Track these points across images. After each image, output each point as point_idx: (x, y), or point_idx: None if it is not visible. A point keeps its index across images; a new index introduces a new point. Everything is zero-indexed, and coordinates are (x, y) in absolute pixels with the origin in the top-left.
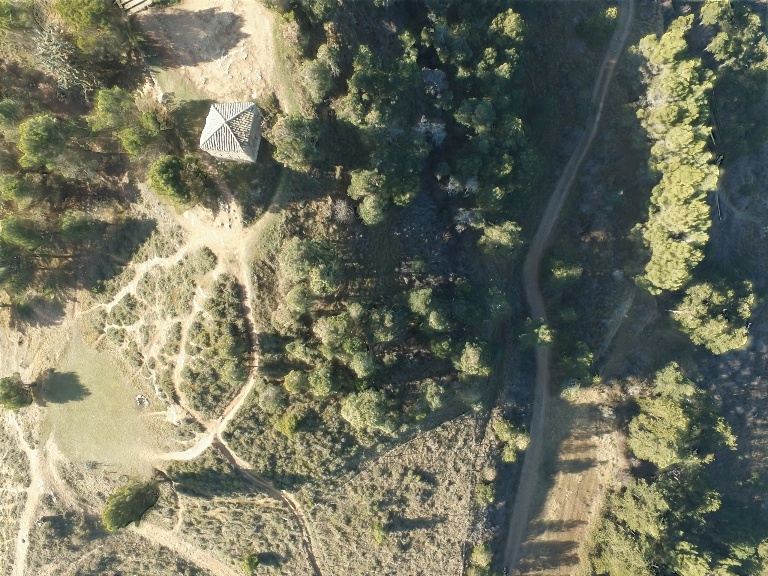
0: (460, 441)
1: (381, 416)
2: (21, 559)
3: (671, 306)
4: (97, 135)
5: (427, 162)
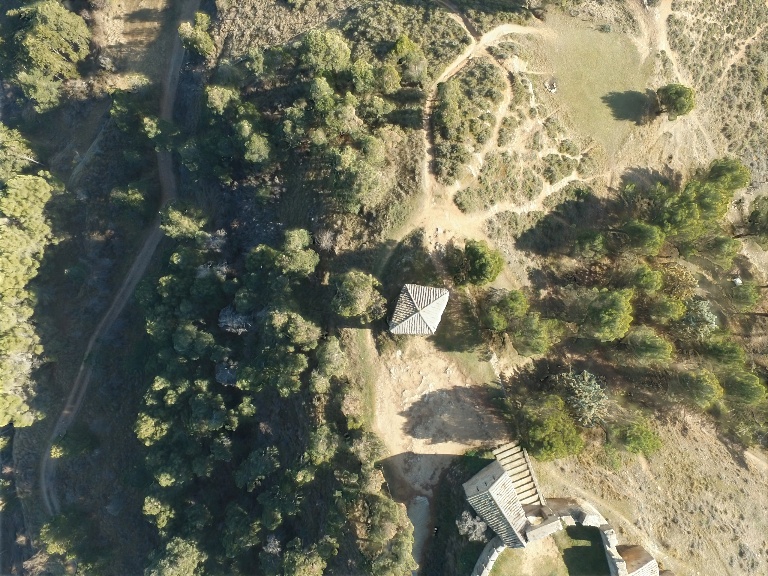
0: (248, 35)
1: None
2: None
3: (36, 167)
4: (569, 339)
5: None
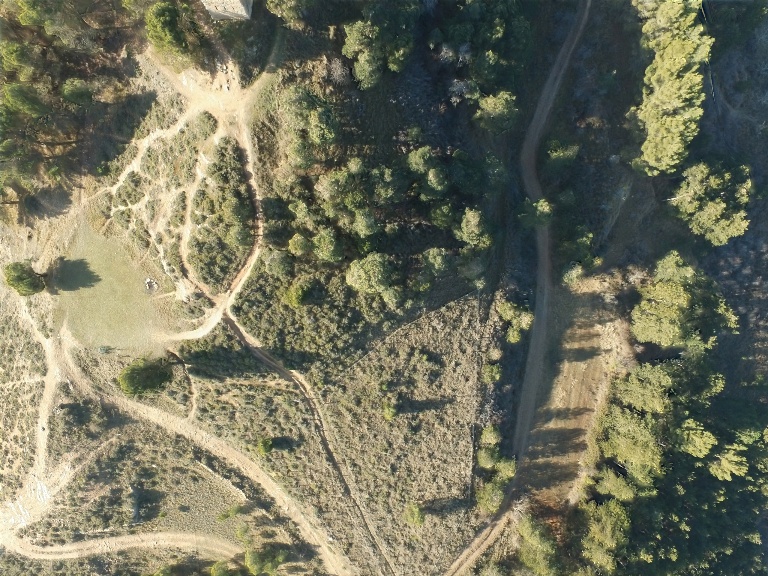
0: (465, 322)
1: (385, 278)
2: (42, 448)
3: (669, 195)
4: (93, 11)
5: (420, 31)
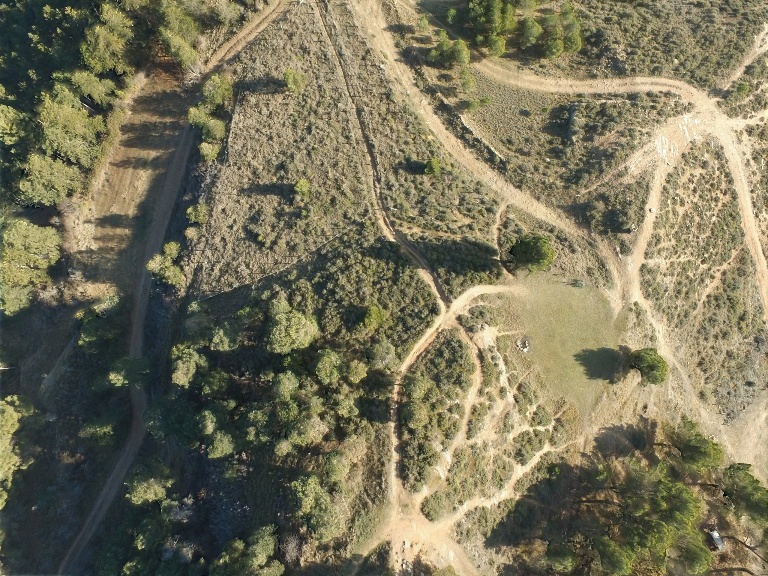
0: (217, 270)
1: None
2: (655, 191)
3: (6, 373)
4: None
5: None
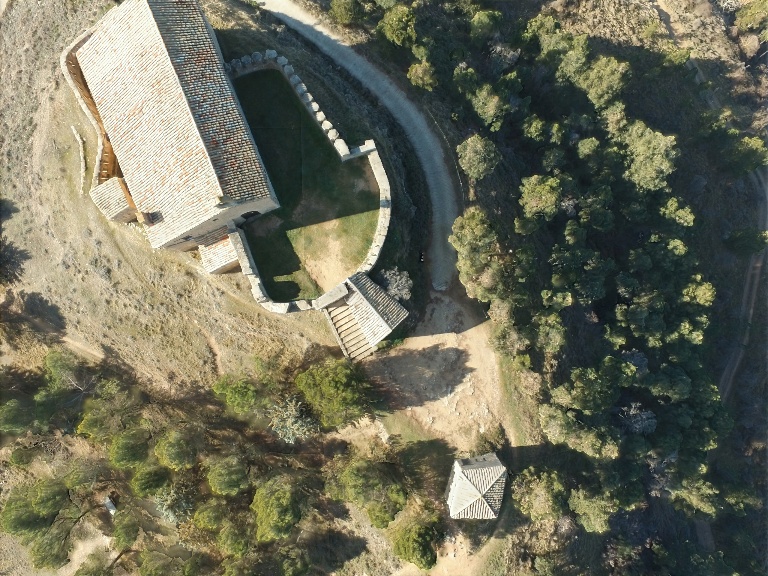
0: None
1: None
2: None
3: None
4: (299, 452)
5: None
